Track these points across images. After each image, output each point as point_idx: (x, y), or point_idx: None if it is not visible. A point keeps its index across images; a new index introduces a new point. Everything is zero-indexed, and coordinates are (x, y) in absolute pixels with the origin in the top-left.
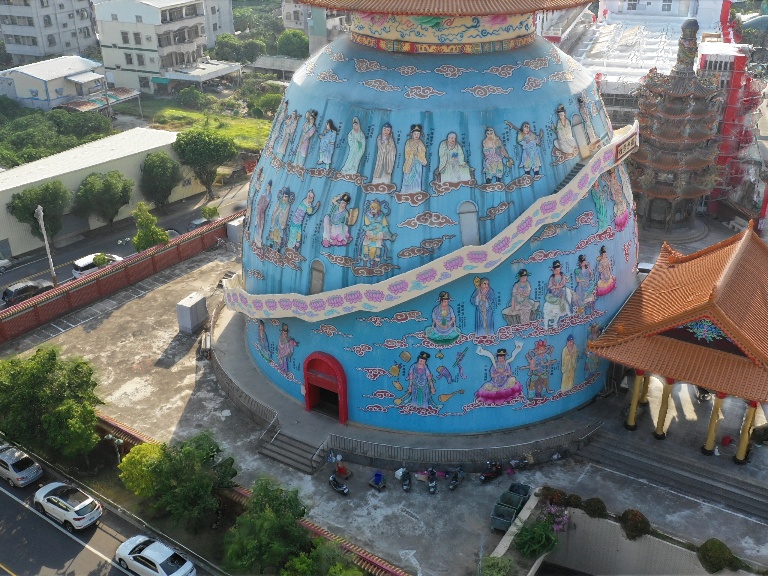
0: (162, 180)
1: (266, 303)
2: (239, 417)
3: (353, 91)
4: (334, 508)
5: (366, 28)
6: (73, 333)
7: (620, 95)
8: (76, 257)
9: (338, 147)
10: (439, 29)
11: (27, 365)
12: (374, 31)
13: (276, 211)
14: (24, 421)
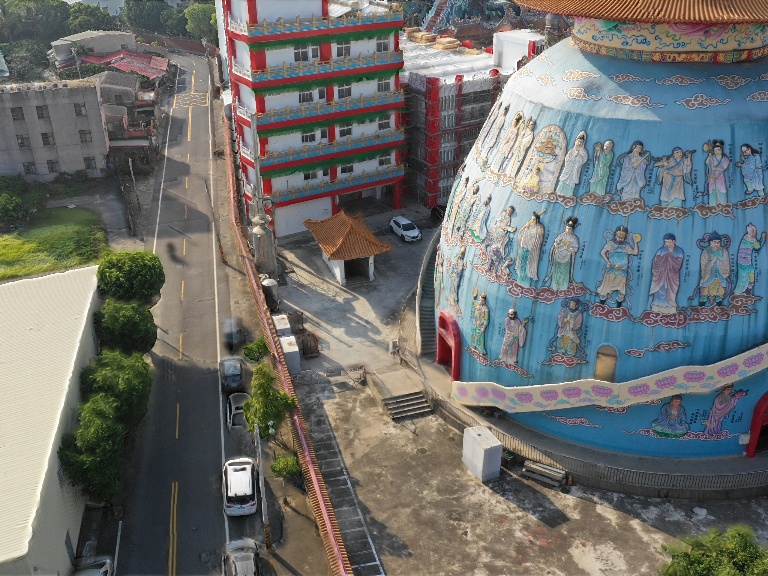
0: (152, 339)
1: (745, 362)
2: (716, 506)
3: (751, 109)
4: None
5: (694, 44)
6: (399, 569)
7: (481, 92)
8: (166, 498)
9: (766, 169)
10: (763, 32)
11: (734, 573)
12: (707, 45)
13: (709, 263)
14: None
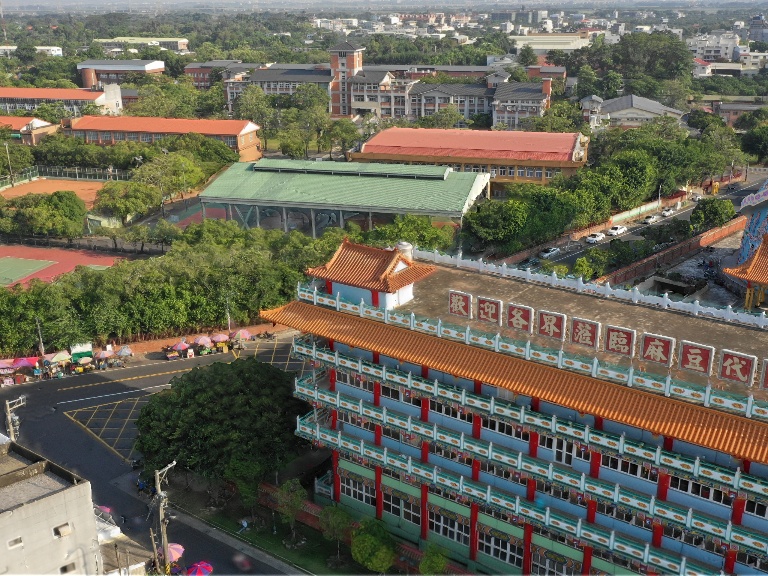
0: None
1: None
2: None
3: None
4: (692, 265)
5: None
6: None
7: None
8: None
9: None
10: None
11: None
12: None
13: None
14: (694, 212)
